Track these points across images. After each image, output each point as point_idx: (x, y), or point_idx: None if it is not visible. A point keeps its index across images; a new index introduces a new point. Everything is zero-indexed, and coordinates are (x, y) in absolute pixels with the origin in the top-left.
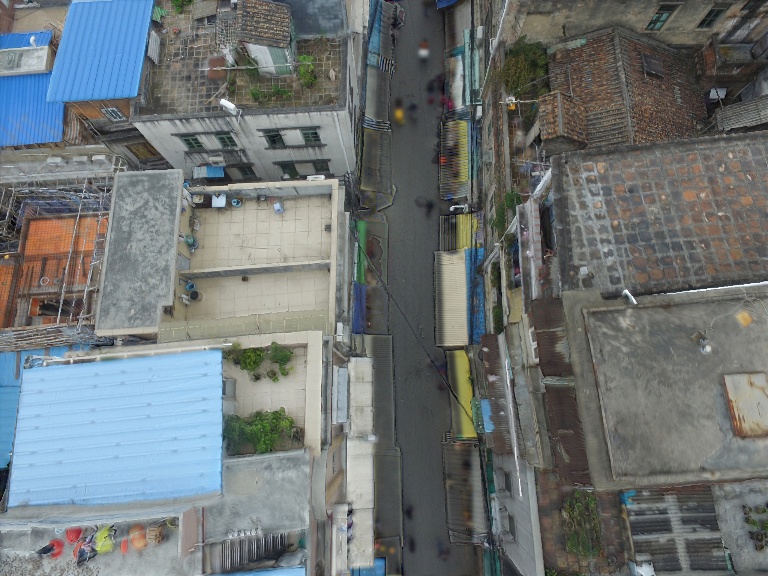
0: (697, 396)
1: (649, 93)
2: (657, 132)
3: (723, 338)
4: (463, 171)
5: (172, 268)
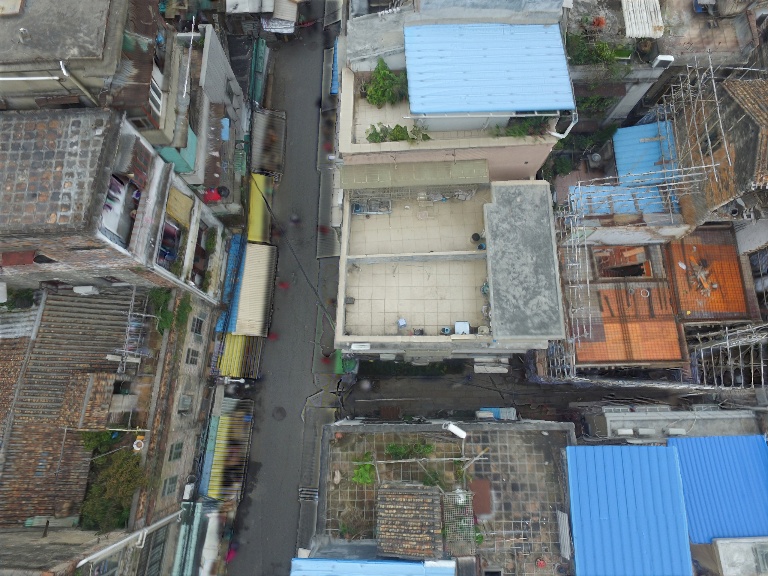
0: (43, 6)
1: None
2: None
3: (8, 39)
4: (224, 429)
5: (488, 236)
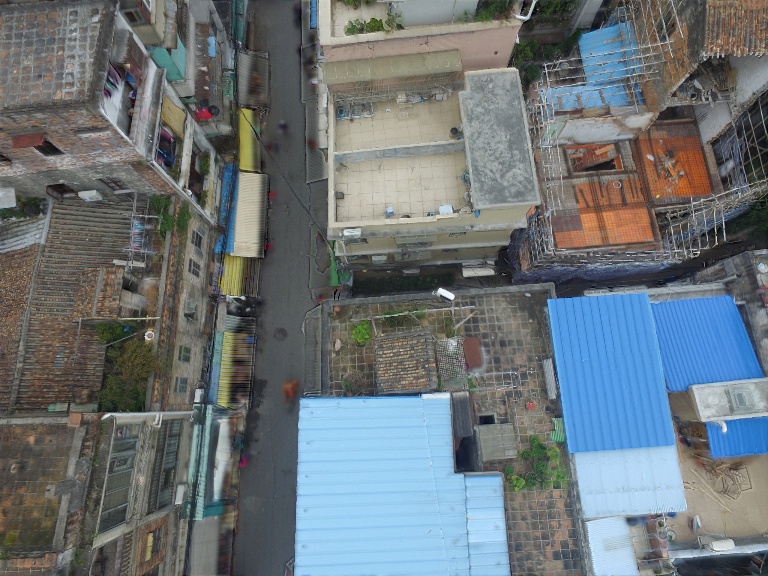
0: None
1: (1, 342)
2: (8, 296)
3: None
4: (228, 344)
5: (464, 120)
